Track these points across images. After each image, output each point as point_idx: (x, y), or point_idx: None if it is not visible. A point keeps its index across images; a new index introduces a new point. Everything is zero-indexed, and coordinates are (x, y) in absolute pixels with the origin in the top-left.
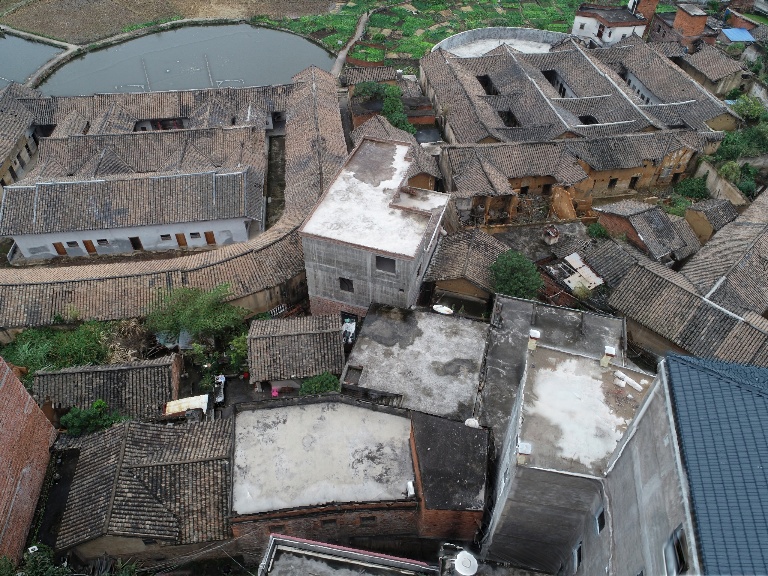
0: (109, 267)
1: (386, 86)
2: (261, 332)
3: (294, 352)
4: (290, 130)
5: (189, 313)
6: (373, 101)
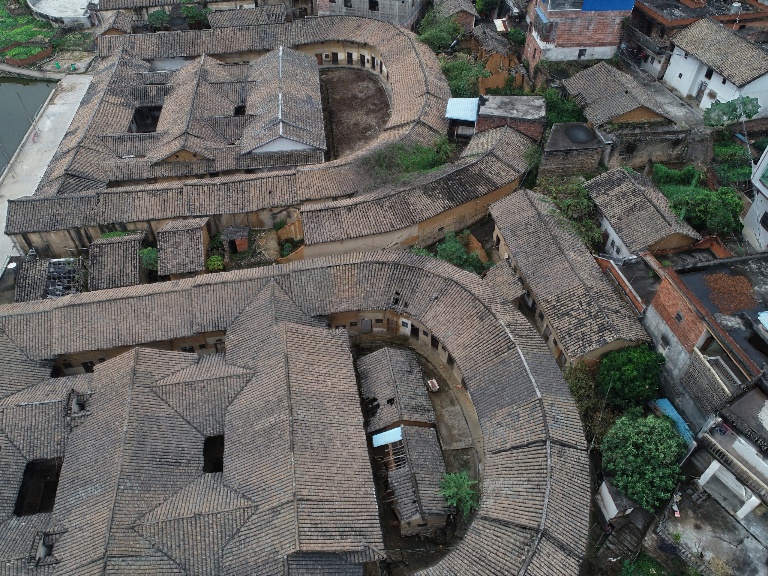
0: (395, 67)
1: (158, 11)
2: (456, 9)
3: (465, 4)
4: (202, 50)
5: (446, 24)
6: (170, 23)
